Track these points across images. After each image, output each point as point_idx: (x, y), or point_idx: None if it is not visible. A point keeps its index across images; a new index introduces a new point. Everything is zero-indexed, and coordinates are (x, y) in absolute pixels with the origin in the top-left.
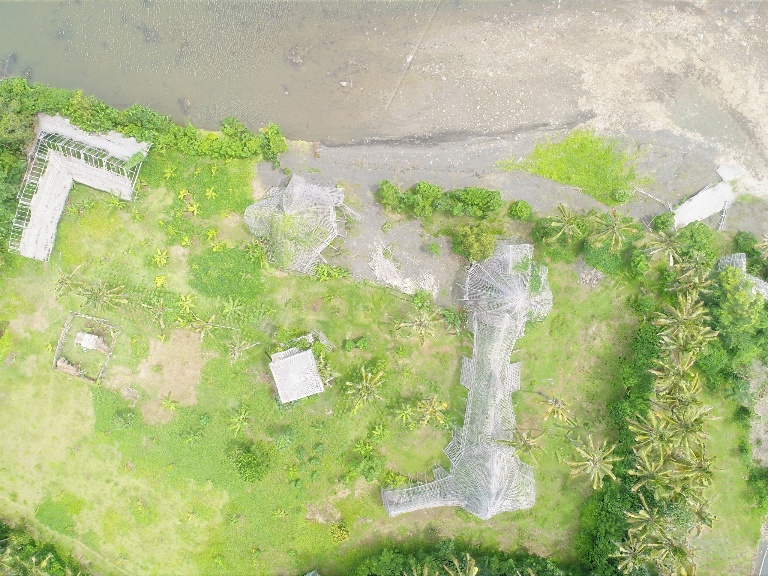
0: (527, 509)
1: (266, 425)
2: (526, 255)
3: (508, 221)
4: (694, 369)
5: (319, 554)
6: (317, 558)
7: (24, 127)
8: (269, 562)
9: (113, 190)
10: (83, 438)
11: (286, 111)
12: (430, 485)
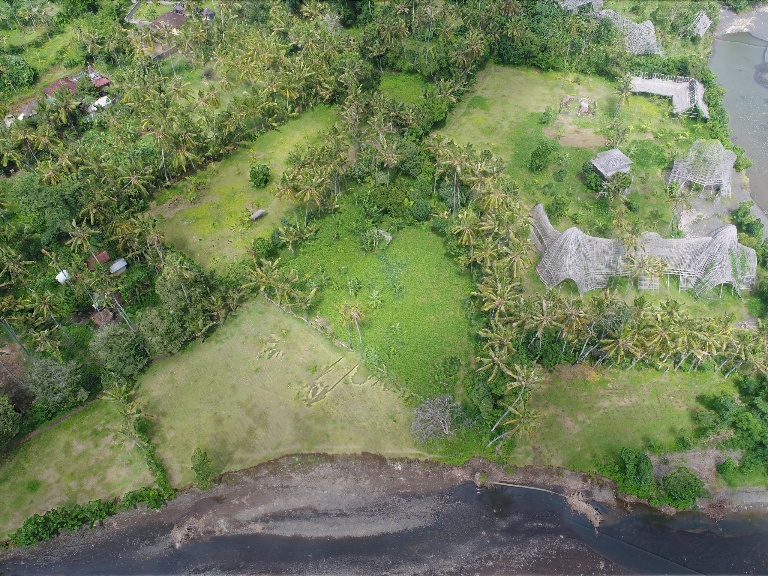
0: None
1: None
2: (749, 270)
3: (760, 278)
4: (708, 404)
5: None
6: None
7: (696, 74)
8: None
9: (676, 107)
10: (525, 109)
11: (760, 178)
12: None
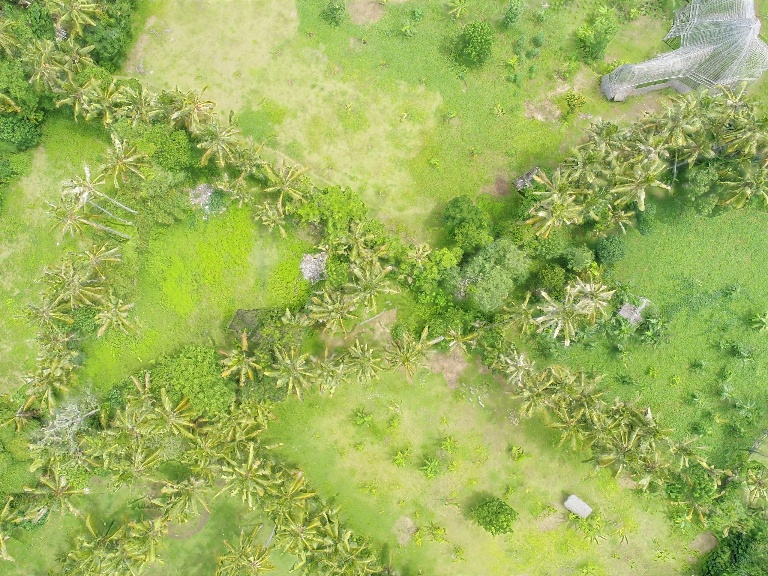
0: (750, 97)
1: (481, 20)
2: None
3: None
4: None
5: (539, 153)
6: (537, 159)
7: None
8: (487, 165)
9: None
10: (286, 42)
11: None
12: (662, 56)
